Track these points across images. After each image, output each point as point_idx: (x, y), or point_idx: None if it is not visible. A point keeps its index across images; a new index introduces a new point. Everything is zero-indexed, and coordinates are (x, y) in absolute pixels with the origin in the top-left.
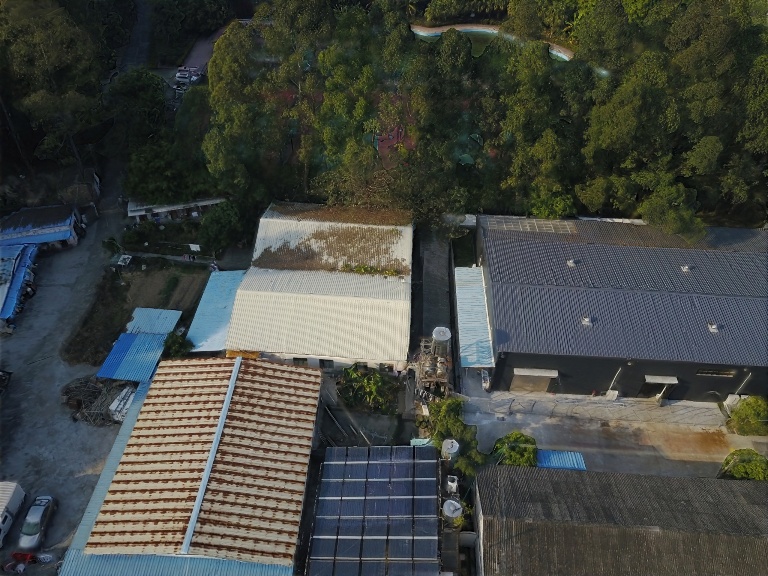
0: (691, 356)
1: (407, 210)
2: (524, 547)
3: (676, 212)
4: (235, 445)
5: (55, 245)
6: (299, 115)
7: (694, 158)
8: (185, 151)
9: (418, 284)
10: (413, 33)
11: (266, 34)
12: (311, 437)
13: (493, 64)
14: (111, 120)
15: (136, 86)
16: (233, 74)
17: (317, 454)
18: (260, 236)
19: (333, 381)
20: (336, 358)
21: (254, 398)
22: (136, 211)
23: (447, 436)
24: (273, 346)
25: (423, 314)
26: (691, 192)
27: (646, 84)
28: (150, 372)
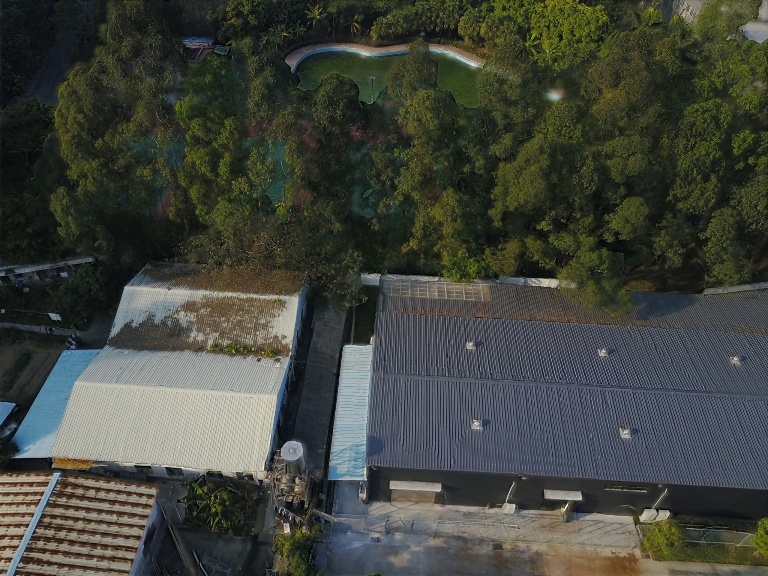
0: (595, 471)
1: (301, 272)
2: None
3: (597, 282)
4: None
5: None
6: (153, 175)
7: (616, 222)
8: (45, 206)
9: None
10: None
11: (109, 82)
12: None
13: (384, 114)
14: None
15: (23, 121)
16: (79, 126)
17: None
18: (121, 308)
19: (184, 491)
20: (183, 467)
21: (62, 531)
22: None
23: None
24: (107, 454)
25: (299, 405)
26: (617, 256)
27: (556, 140)
28: None
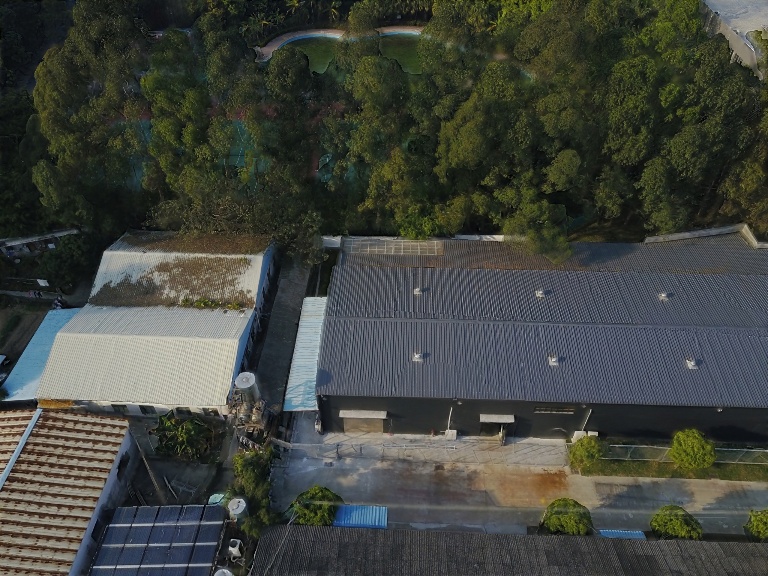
0: (523, 394)
1: (268, 235)
2: None
3: (537, 231)
4: (8, 511)
5: None
6: (122, 144)
7: (552, 174)
8: (31, 182)
9: None
10: (253, 51)
11: (78, 60)
12: (98, 497)
13: (332, 81)
14: None
15: (13, 110)
16: (54, 103)
17: (109, 514)
18: (101, 270)
19: None
20: (154, 404)
21: (44, 455)
22: None
23: (239, 494)
24: (86, 393)
25: (262, 350)
26: (559, 208)
27: (490, 98)
28: None
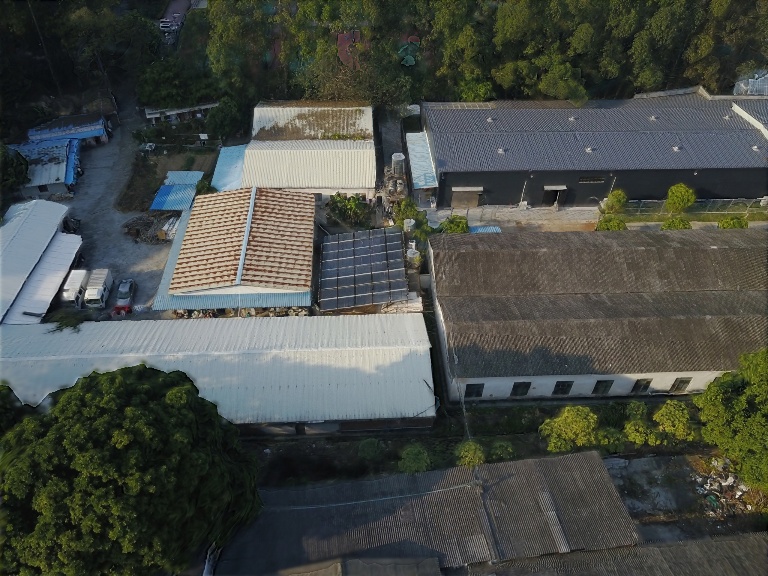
0: (573, 166)
1: (366, 101)
2: (460, 265)
3: (565, 83)
4: (261, 232)
5: (91, 142)
6: (281, 20)
7: (574, 41)
8: (189, 62)
9: (379, 149)
10: None
11: None
12: None
13: None
14: (117, 53)
15: None
16: None
17: (317, 242)
18: (256, 120)
19: (322, 210)
20: (324, 191)
21: (269, 209)
22: (153, 114)
23: None
24: (277, 184)
25: (384, 164)
26: (577, 70)
27: None
28: (189, 204)
